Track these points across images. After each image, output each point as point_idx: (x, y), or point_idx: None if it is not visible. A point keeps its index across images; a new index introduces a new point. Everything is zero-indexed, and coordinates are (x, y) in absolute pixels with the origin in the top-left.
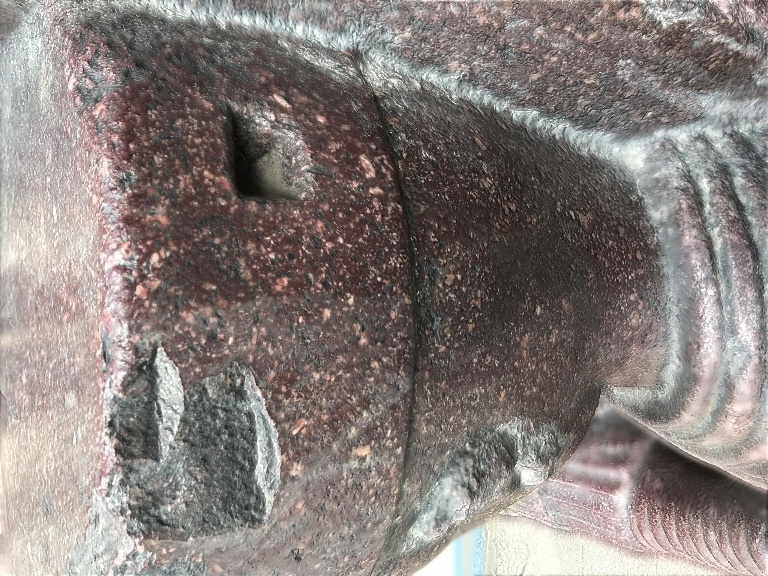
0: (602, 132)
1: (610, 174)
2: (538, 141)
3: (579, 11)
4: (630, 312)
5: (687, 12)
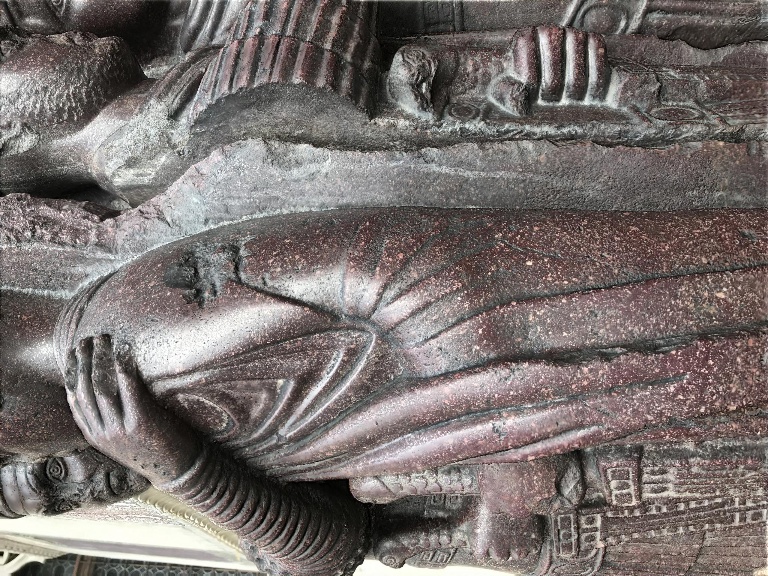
0: (62, 289)
1: (64, 303)
2: (30, 297)
3: (2, 255)
4: (42, 348)
5: (33, 245)
